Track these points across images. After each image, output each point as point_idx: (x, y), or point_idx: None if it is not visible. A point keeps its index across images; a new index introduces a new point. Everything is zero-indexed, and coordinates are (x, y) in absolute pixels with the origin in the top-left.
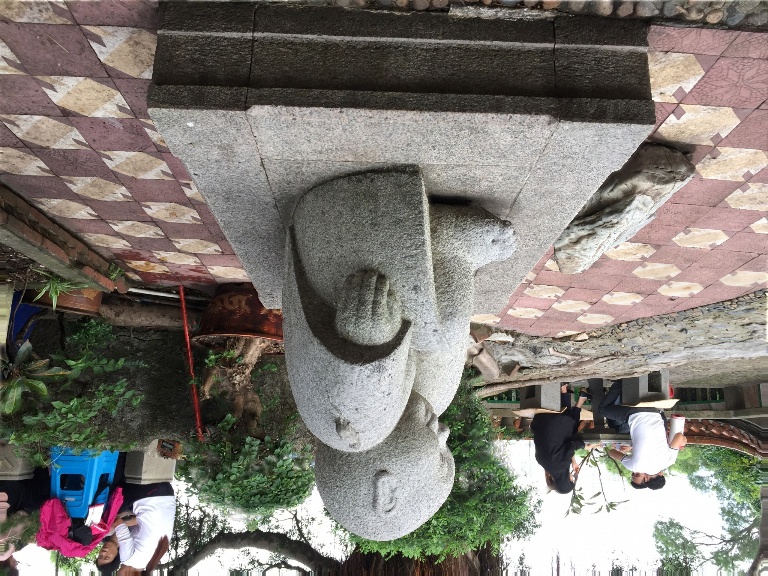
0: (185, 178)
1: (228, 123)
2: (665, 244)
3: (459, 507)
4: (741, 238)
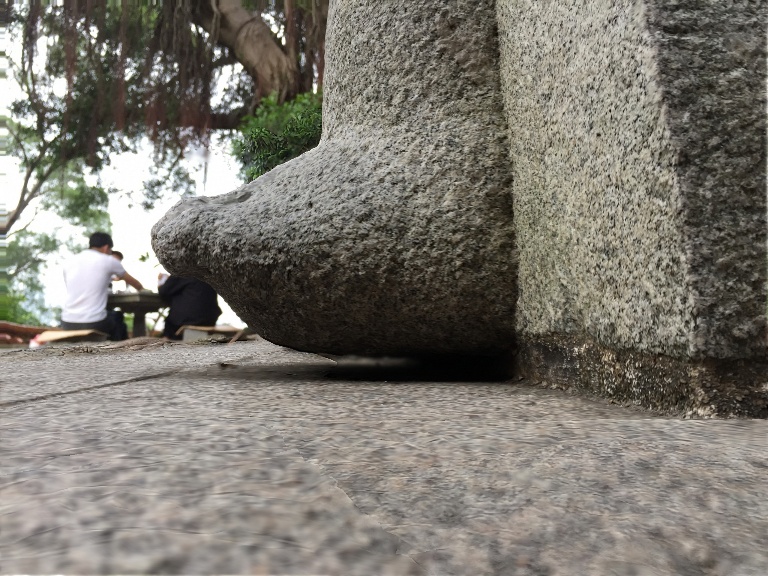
0: None
1: None
2: None
3: (320, 131)
4: None
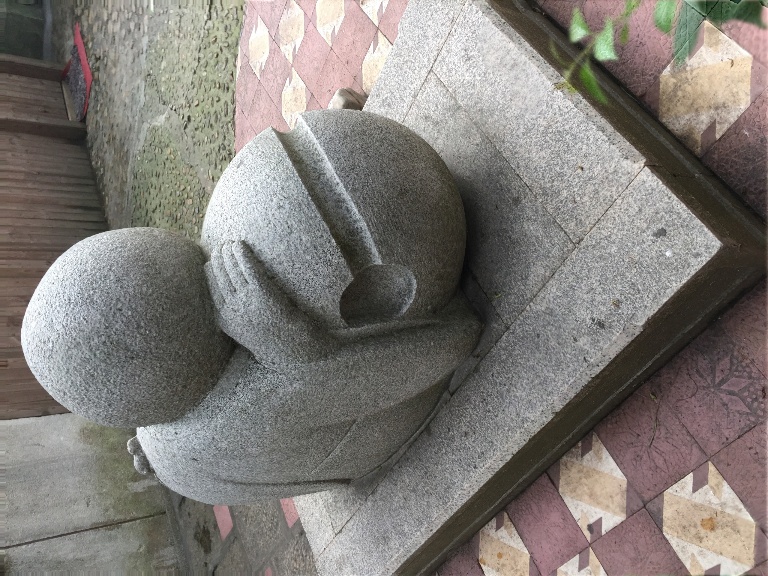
0: (578, 535)
1: (324, 570)
2: (351, 1)
3: None
4: (311, 1)
